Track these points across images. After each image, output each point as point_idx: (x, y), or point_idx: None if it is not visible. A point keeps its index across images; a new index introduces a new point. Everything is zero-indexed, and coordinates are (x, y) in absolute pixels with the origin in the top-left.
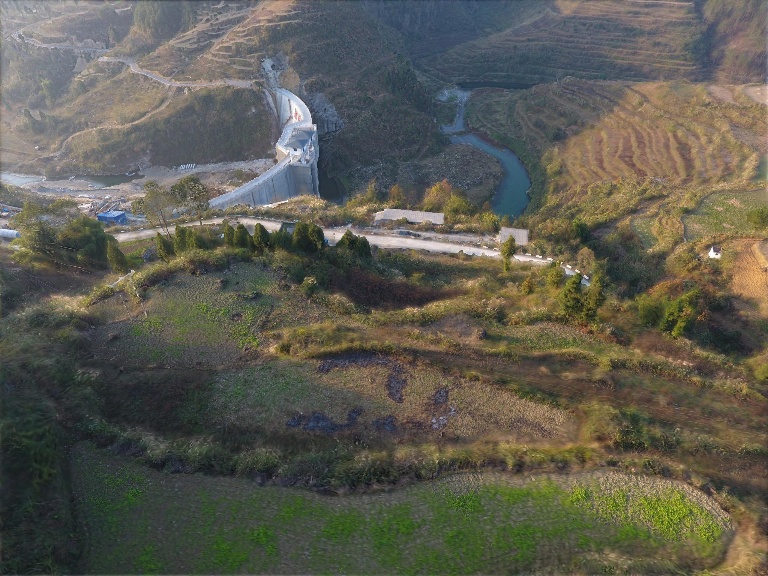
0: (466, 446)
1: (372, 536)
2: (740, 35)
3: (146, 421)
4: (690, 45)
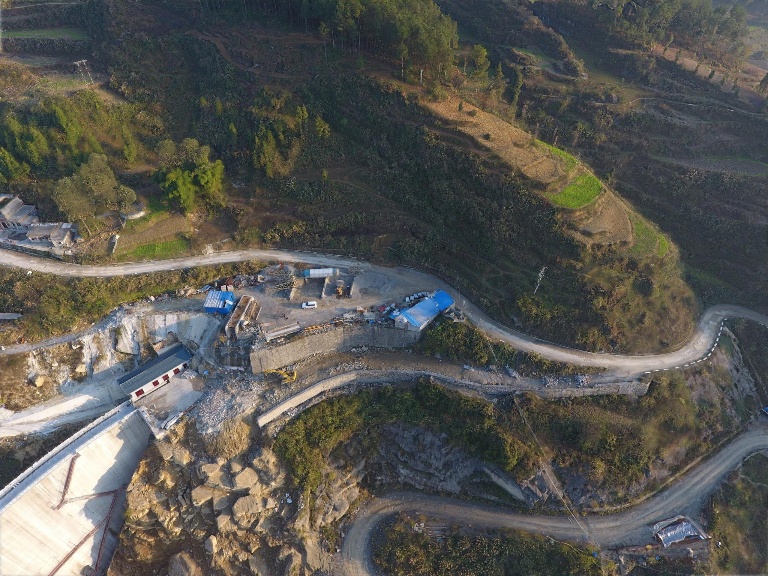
0: None
1: None
2: None
3: (80, 56)
4: None
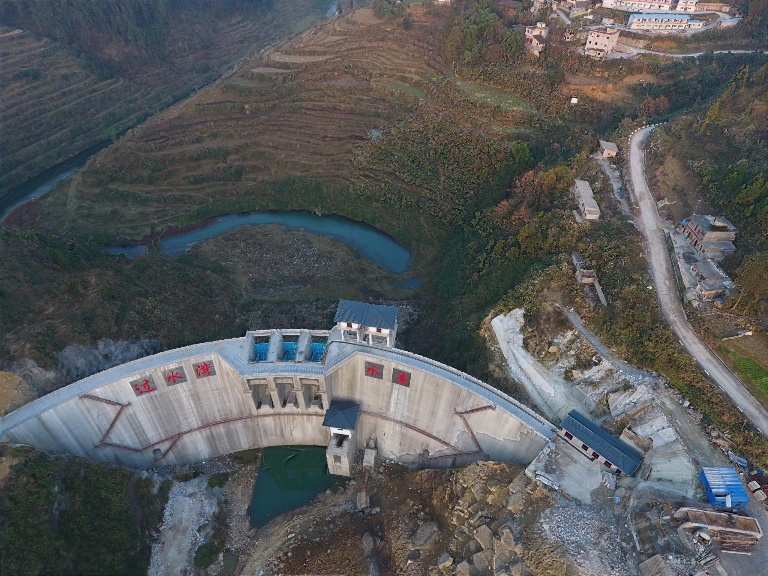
0: None
1: None
2: (105, 41)
3: None
4: (92, 65)
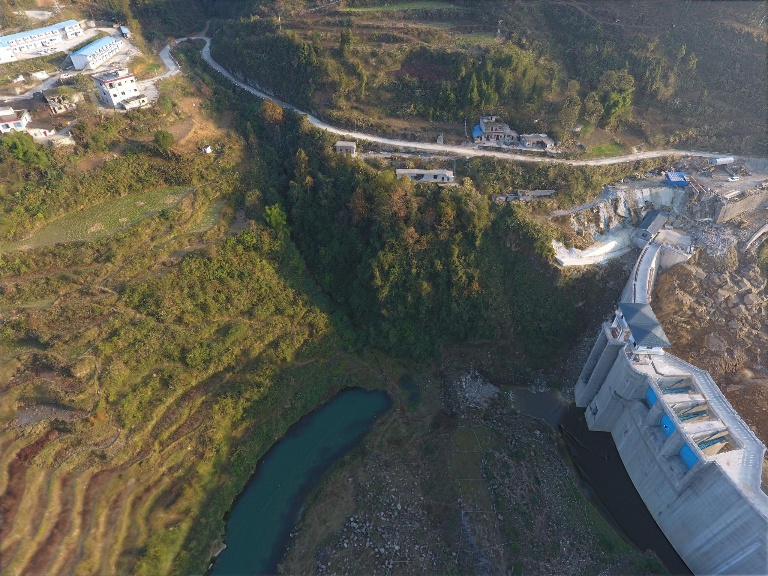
0: (388, 20)
1: None
2: None
3: None
4: None
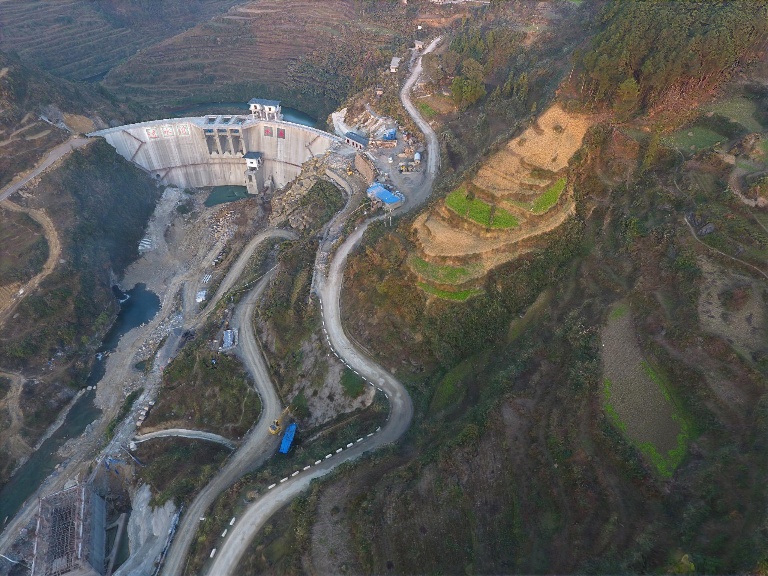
0: None
1: (578, 2)
2: (117, 2)
3: None
4: (108, 17)
